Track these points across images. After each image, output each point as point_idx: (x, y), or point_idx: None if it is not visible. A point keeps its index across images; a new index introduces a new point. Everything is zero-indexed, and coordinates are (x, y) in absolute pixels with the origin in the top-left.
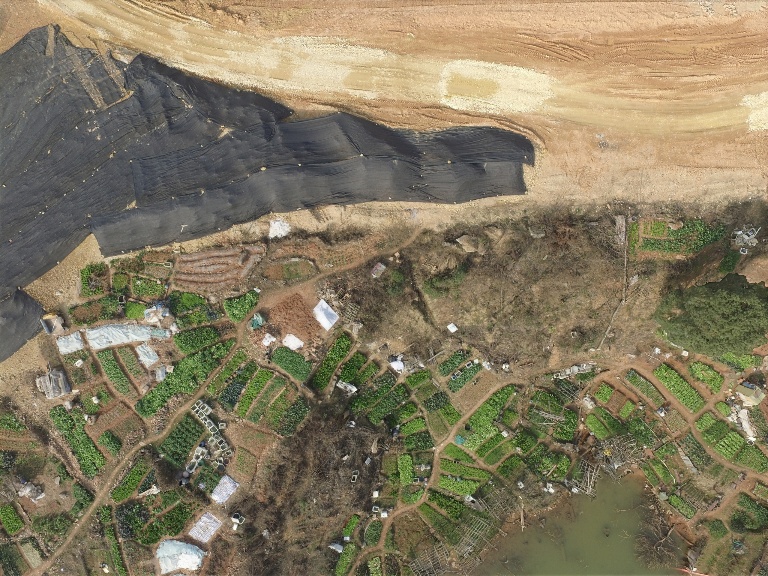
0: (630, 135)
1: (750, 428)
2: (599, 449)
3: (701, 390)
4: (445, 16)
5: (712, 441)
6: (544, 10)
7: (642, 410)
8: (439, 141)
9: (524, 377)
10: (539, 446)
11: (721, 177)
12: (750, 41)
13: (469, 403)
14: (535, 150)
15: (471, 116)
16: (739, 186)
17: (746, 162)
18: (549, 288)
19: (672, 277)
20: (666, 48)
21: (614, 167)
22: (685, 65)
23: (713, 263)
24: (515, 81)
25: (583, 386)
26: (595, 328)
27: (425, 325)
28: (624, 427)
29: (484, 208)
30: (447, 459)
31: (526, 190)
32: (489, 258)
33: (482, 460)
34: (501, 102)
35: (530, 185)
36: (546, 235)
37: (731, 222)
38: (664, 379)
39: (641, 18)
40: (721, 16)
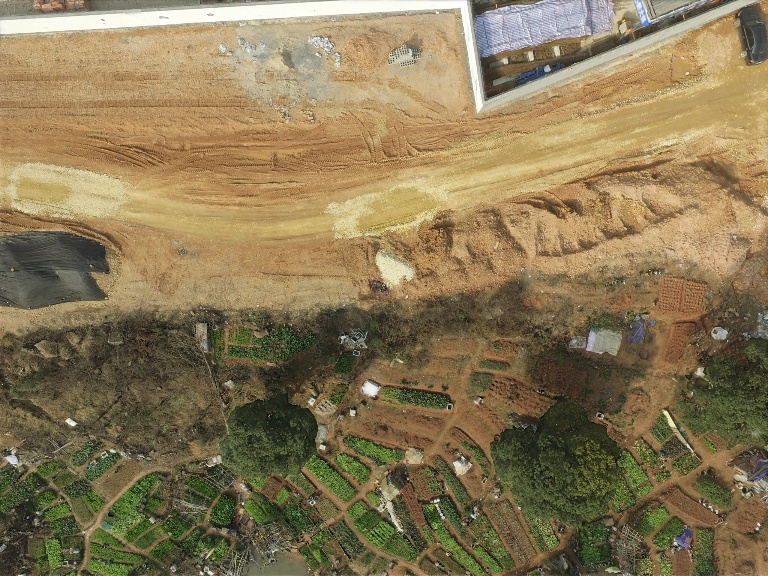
0: (209, 242)
1: (395, 520)
2: (244, 537)
3: (351, 480)
4: (6, 119)
5: (363, 530)
6: (110, 114)
7: (297, 497)
8: (8, 247)
9: (170, 465)
10: (194, 530)
11: (309, 285)
12: (333, 147)
13: (112, 490)
14: (107, 257)
15: (42, 221)
16: (329, 294)
17: (334, 270)
18: (145, 391)
19: (268, 382)
20: (246, 153)
21: (196, 274)
22: (265, 171)
23: (321, 366)
24: (88, 186)
25: (227, 476)
26: (217, 424)
27: (38, 420)
28: (282, 513)
29: (65, 313)
30: (97, 543)
31: (106, 296)
32: (77, 361)
33: (133, 544)
34: (75, 207)
35: (110, 291)
36: (124, 342)
37: (318, 331)
38: (312, 469)
39: (214, 123)
40: (299, 122)
